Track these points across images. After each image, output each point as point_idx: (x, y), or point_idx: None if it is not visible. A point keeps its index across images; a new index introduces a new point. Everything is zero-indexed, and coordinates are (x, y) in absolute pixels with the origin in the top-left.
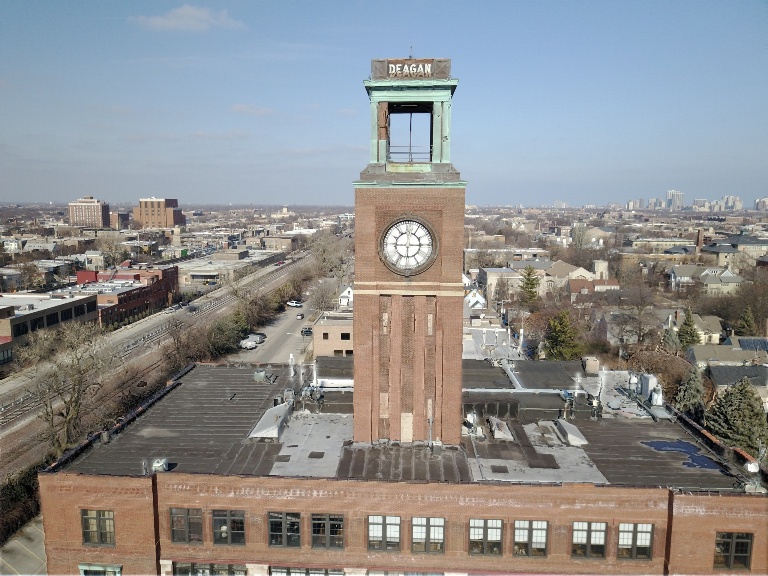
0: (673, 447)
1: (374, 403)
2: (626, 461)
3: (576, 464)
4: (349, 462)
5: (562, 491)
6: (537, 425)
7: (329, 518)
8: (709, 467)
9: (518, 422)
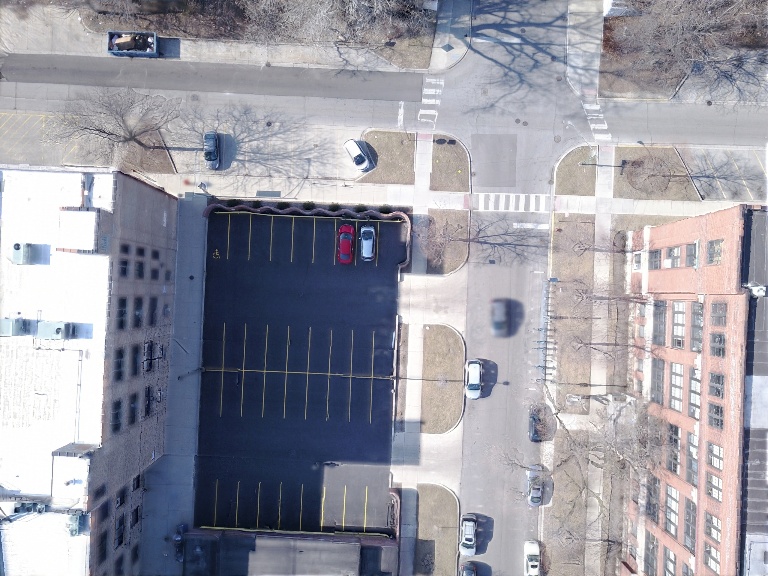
0: None
1: None
2: None
3: None
4: None
5: None
6: None
7: None
8: None
9: None
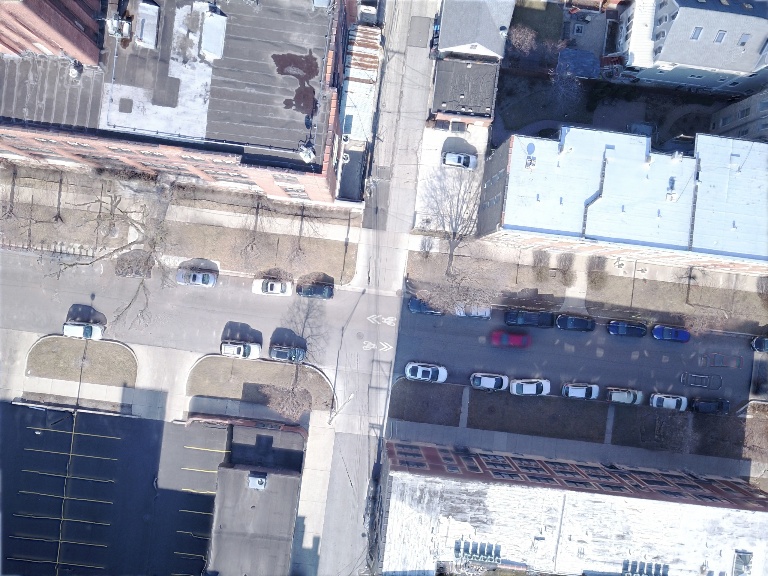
0: (296, 67)
1: (0, 38)
2: (238, 95)
3: (193, 98)
4: (2, 85)
5: (161, 148)
6: (191, 9)
7: (1, 134)
8: (301, 110)
9: (173, 2)
